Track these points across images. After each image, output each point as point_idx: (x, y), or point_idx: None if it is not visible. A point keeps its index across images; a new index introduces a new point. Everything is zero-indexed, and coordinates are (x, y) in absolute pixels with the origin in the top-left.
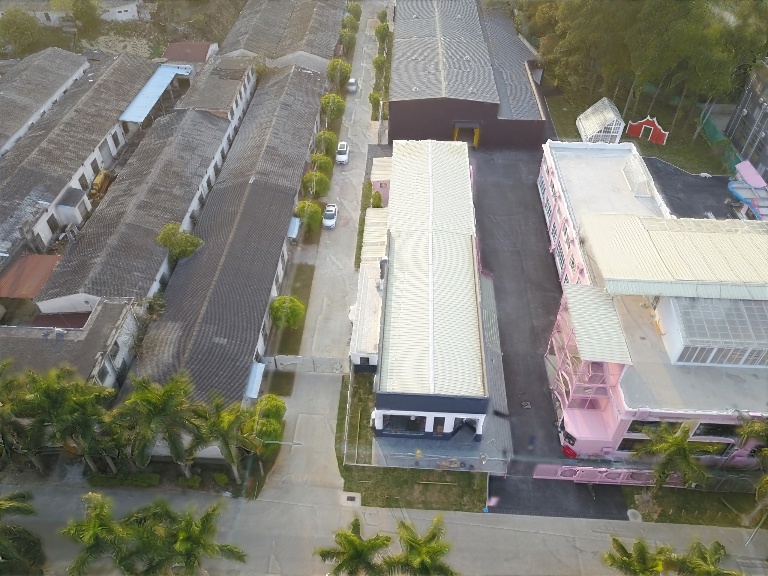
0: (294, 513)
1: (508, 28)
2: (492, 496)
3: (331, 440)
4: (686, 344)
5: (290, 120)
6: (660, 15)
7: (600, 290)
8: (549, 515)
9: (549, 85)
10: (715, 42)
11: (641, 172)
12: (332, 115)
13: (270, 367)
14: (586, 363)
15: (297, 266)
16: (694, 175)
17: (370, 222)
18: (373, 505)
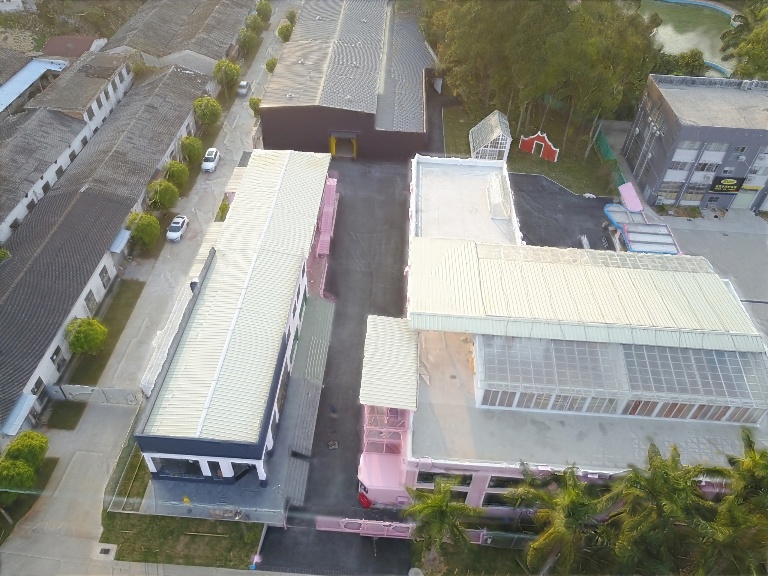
0: (34, 568)
1: (417, 34)
2: (264, 550)
3: (103, 482)
4: (482, 388)
5: (151, 124)
6: (538, 27)
7: (408, 324)
8: (321, 573)
9: (450, 95)
10: (595, 58)
11: (498, 193)
12: (205, 119)
13: (59, 396)
14: (369, 407)
15: (126, 283)
16: (578, 195)
17: (210, 237)
18: (127, 559)
